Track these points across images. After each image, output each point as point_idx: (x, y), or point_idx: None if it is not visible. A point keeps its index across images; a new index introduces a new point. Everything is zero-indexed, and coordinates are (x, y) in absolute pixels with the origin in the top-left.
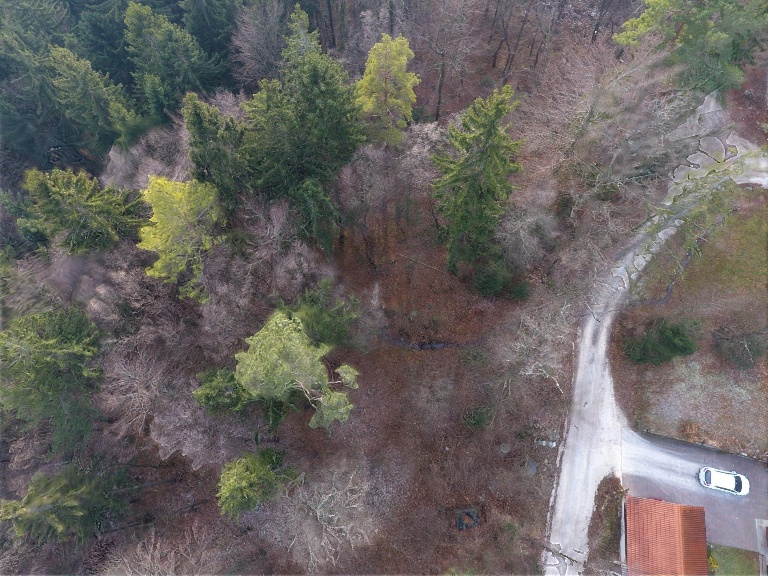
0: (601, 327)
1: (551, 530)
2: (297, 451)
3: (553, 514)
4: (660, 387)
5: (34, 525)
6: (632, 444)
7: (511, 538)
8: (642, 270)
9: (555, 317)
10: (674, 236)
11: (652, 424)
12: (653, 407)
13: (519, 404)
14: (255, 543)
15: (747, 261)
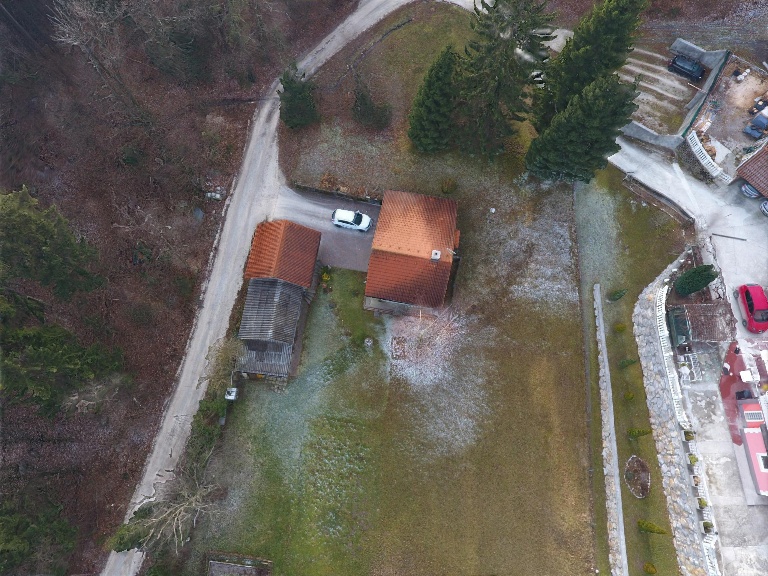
0: (276, 109)
1: (213, 267)
2: None
3: (216, 254)
4: (310, 149)
5: None
6: (286, 197)
7: None
8: (321, 66)
9: (98, 7)
10: (354, 40)
11: (299, 178)
12: (301, 164)
13: (192, 164)
14: None
15: (403, 54)
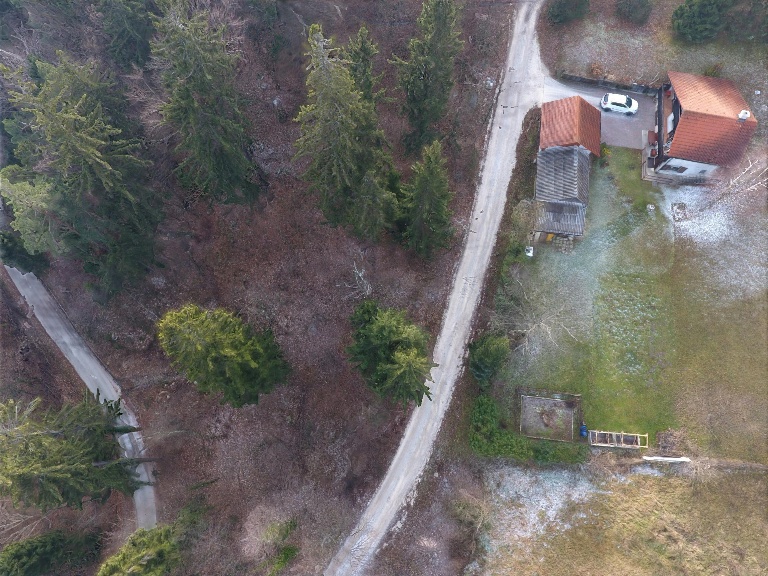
0: (532, 10)
1: (488, 148)
2: (294, 95)
3: (490, 137)
4: (574, 43)
5: (112, 9)
6: (552, 87)
7: (454, 134)
8: None
9: None
10: None
11: (567, 68)
12: (568, 55)
13: (465, 56)
14: (260, 179)
15: None
